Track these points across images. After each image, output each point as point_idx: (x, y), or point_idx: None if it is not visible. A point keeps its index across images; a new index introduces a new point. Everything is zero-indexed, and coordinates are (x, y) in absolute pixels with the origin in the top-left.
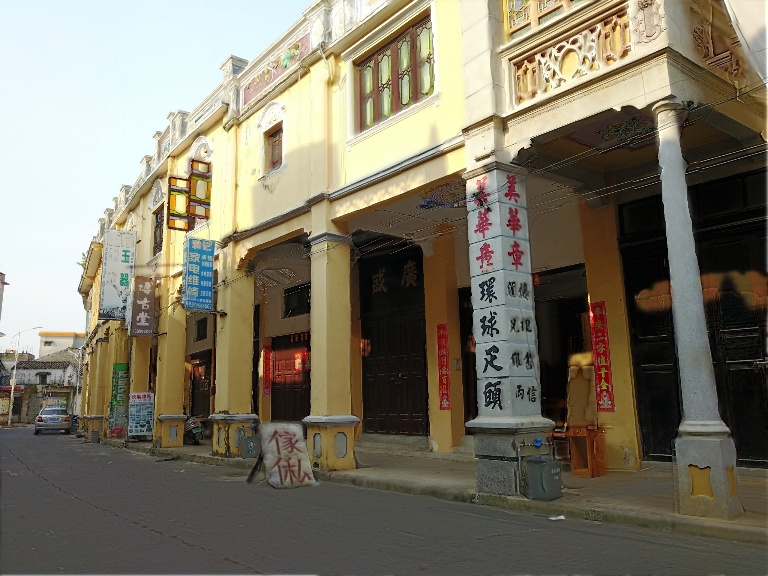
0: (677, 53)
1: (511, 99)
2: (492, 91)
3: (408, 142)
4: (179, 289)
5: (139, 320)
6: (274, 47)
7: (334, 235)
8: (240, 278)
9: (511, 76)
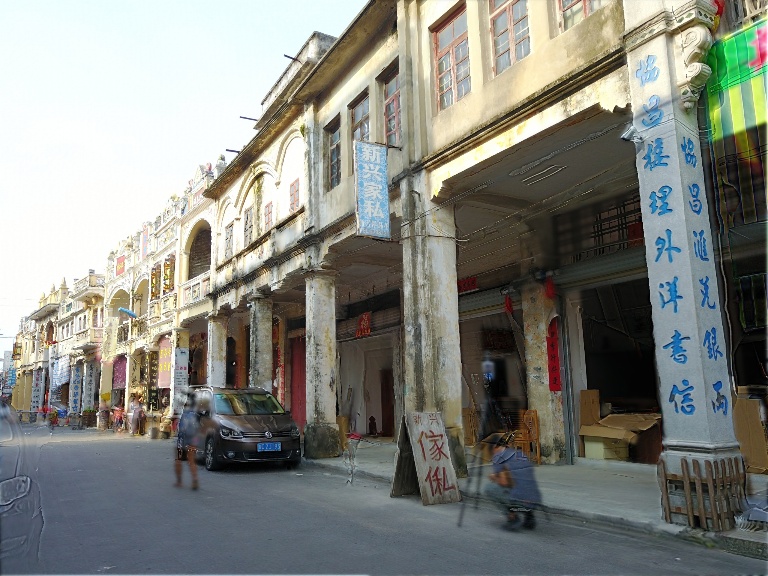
0: (43, 361)
1: (39, 358)
2: (36, 357)
3: (33, 359)
4: (18, 375)
5: (6, 384)
6: (27, 323)
7: (28, 373)
8: (23, 377)
9: (39, 354)
